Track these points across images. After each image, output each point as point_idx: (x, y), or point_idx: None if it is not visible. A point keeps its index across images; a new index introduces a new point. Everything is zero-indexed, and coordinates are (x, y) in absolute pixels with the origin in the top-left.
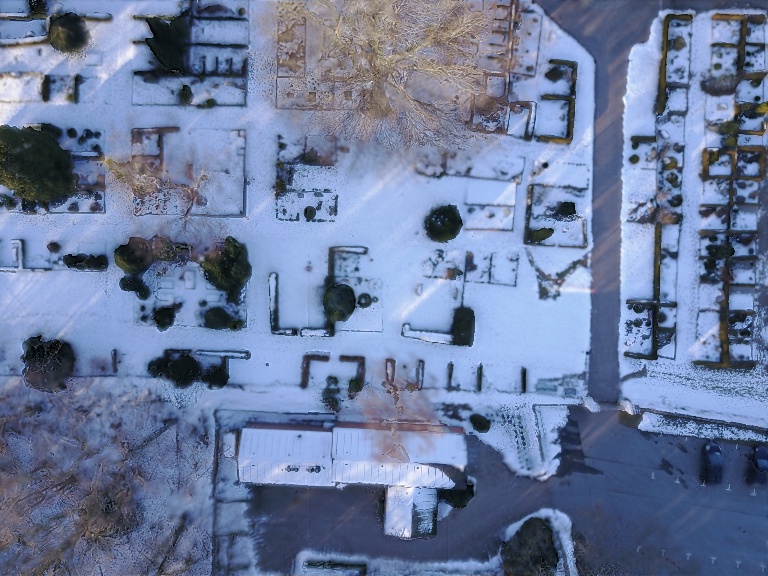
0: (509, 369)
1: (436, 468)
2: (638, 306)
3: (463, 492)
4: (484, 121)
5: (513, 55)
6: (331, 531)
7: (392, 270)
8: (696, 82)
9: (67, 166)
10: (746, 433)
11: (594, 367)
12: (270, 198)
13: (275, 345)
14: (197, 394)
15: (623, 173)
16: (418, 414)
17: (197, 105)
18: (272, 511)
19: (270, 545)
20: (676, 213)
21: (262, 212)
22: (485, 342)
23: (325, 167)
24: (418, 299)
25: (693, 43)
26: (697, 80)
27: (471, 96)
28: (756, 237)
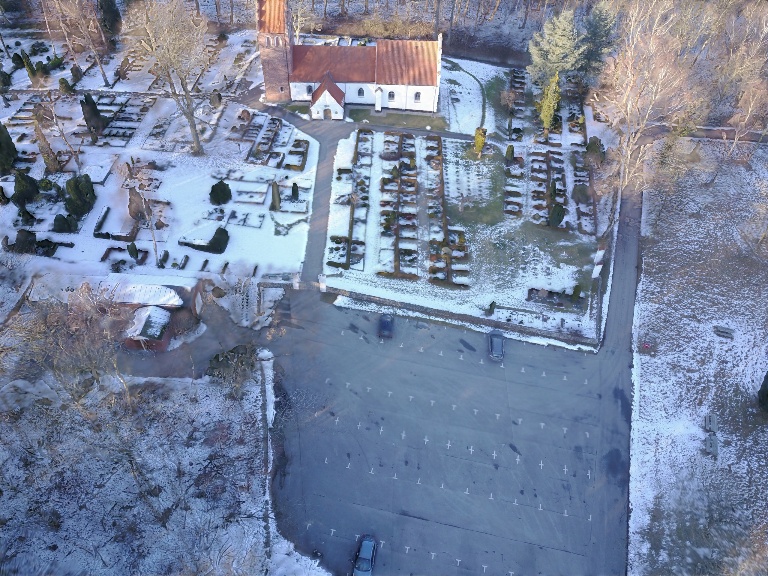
0: (247, 267)
1: (171, 289)
2: (337, 239)
3: (188, 310)
4: (255, 159)
5: (275, 137)
6: None
7: (183, 215)
8: (376, 155)
9: (13, 152)
10: (414, 313)
11: (306, 270)
12: (121, 180)
13: (93, 243)
14: (27, 261)
15: (332, 184)
16: None
17: (98, 145)
18: None
19: None
20: (364, 203)
21: (114, 185)
22: (234, 252)
23: (159, 171)
24: (195, 228)
25: (374, 141)
26: (377, 154)
27: None
28: (417, 218)
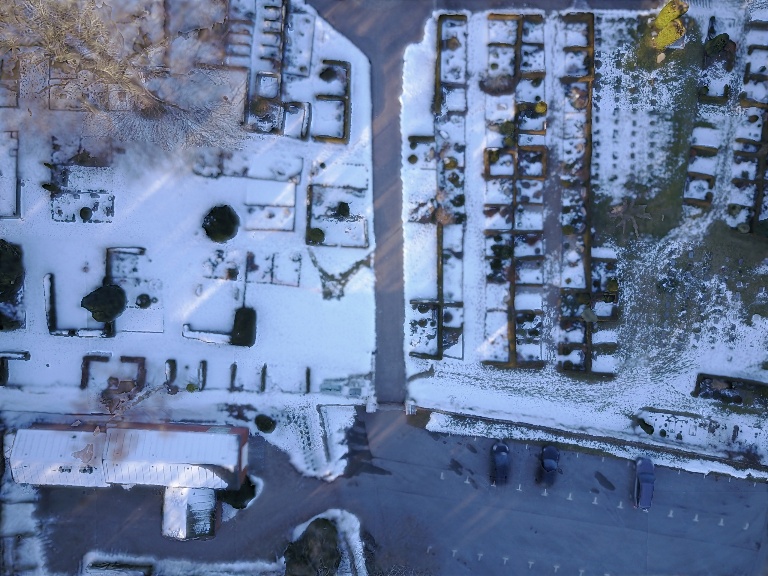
0: (294, 369)
1: (206, 469)
2: (421, 306)
3: (237, 493)
4: (259, 122)
5: (285, 56)
6: (118, 532)
7: (172, 271)
8: (474, 82)
9: None
10: (536, 433)
11: (380, 367)
12: (45, 199)
13: (55, 346)
14: None
15: (402, 173)
16: (203, 415)
17: None
18: (59, 512)
19: (58, 546)
20: (458, 213)
21: (37, 213)
22: (269, 342)
23: (101, 168)
24: (199, 300)
25: (469, 43)
26: (475, 80)
27: (244, 97)
28: (543, 237)
